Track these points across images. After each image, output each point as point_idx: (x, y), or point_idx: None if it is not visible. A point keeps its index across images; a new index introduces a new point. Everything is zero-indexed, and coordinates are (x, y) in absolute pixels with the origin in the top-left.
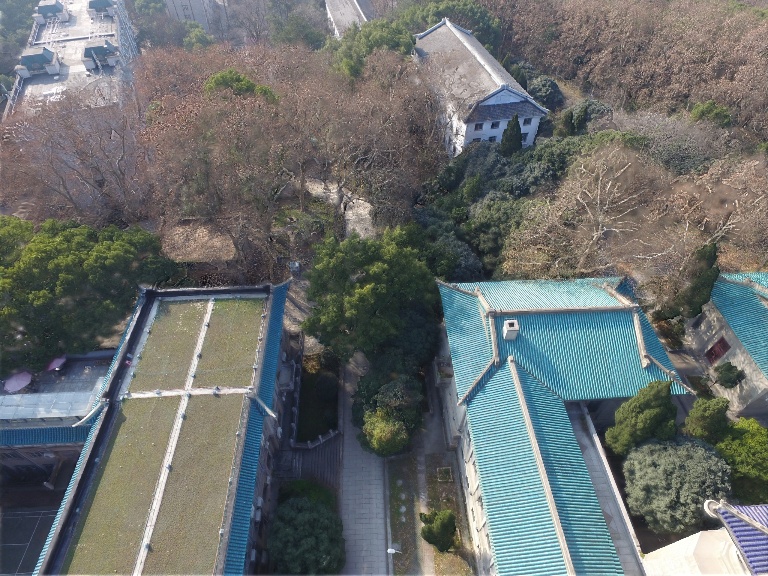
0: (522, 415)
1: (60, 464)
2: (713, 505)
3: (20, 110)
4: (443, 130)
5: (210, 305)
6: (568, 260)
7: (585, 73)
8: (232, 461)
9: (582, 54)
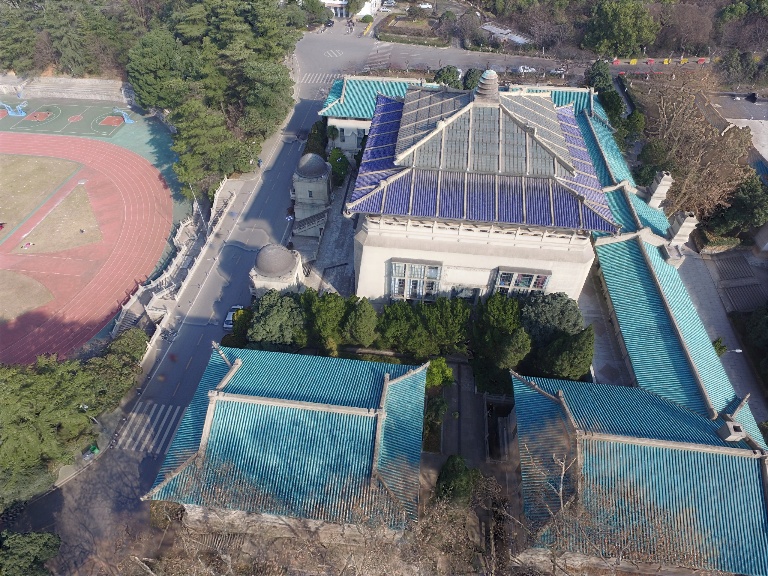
0: None
1: None
2: (618, 235)
3: None
4: None
5: None
6: None
7: None
8: None
9: None
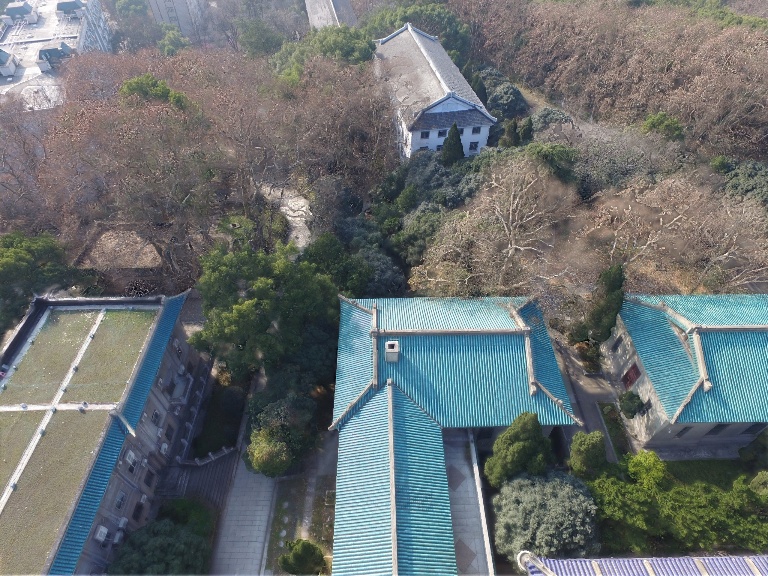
0: (388, 443)
1: None
2: (526, 557)
3: None
4: (389, 138)
5: (100, 316)
6: (491, 276)
7: (552, 80)
8: None
9: (549, 61)
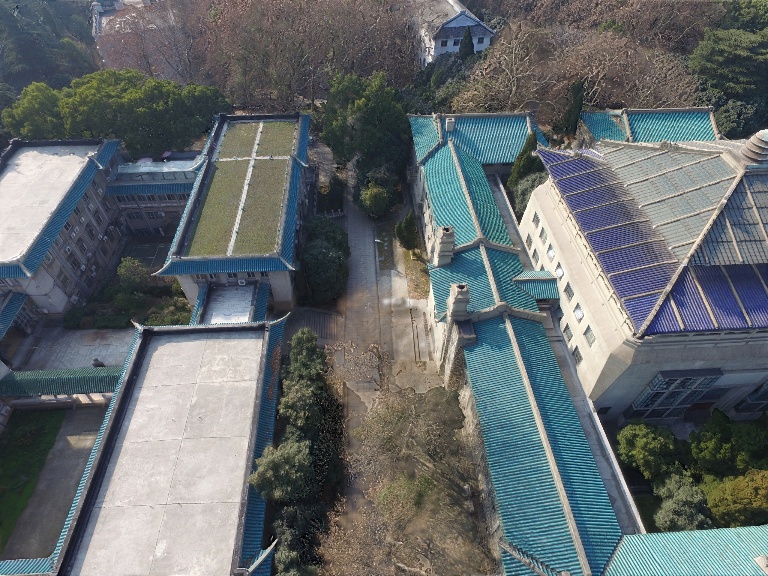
0: (454, 162)
1: (166, 224)
2: None
3: (128, 8)
4: (418, 47)
5: (261, 124)
6: None
7: (533, 17)
8: (284, 183)
9: (530, 2)
